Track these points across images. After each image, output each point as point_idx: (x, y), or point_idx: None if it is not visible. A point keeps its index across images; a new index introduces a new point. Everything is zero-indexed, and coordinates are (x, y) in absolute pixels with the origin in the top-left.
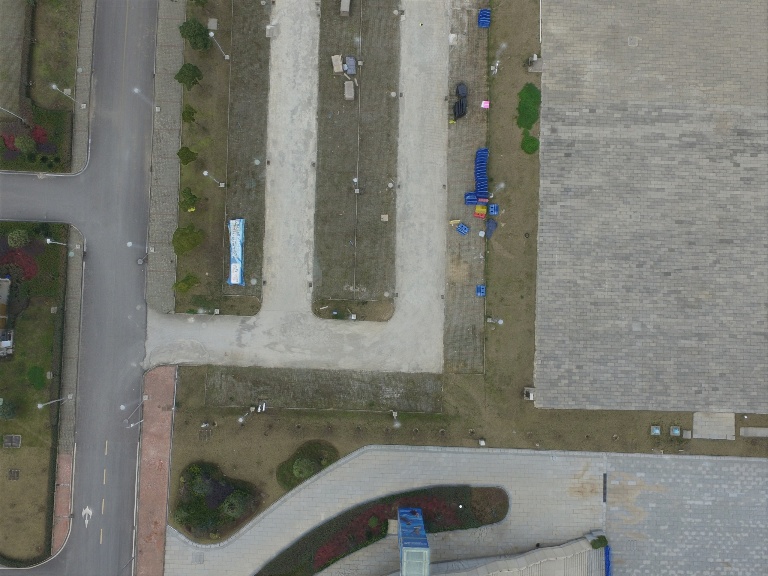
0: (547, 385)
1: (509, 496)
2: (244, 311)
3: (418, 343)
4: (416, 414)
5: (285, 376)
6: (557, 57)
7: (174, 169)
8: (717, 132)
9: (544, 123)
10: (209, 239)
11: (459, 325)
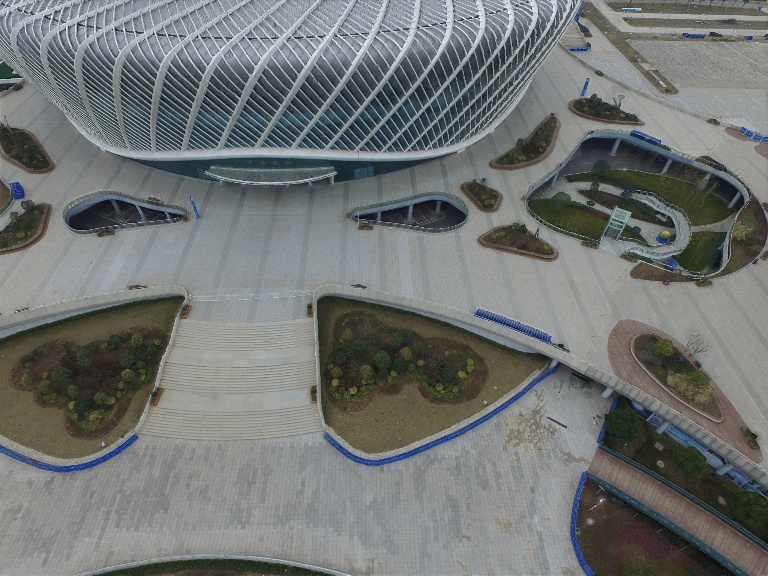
0: (635, 41)
1: (591, 37)
2: (615, 10)
3: (628, 29)
4: (605, 28)
5: (600, 14)
6: (751, 44)
7: (648, 2)
8: (762, 68)
9: (725, 42)
10: (632, 6)
11: (640, 34)
